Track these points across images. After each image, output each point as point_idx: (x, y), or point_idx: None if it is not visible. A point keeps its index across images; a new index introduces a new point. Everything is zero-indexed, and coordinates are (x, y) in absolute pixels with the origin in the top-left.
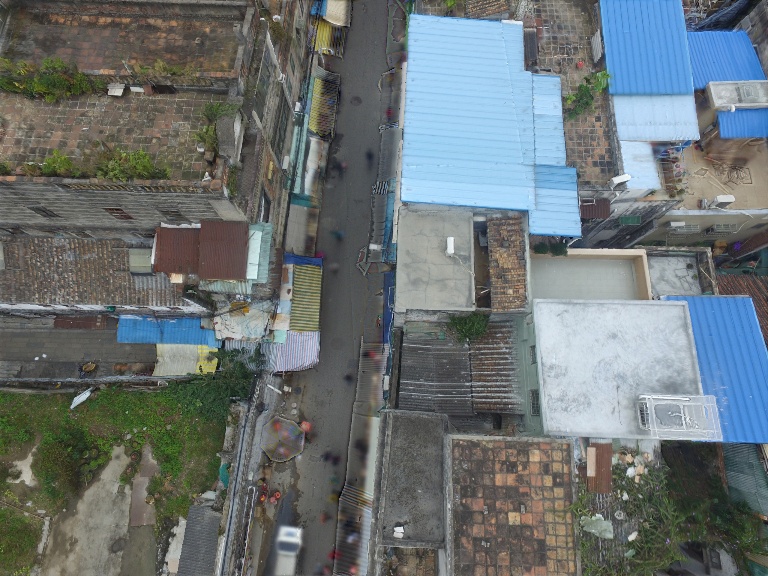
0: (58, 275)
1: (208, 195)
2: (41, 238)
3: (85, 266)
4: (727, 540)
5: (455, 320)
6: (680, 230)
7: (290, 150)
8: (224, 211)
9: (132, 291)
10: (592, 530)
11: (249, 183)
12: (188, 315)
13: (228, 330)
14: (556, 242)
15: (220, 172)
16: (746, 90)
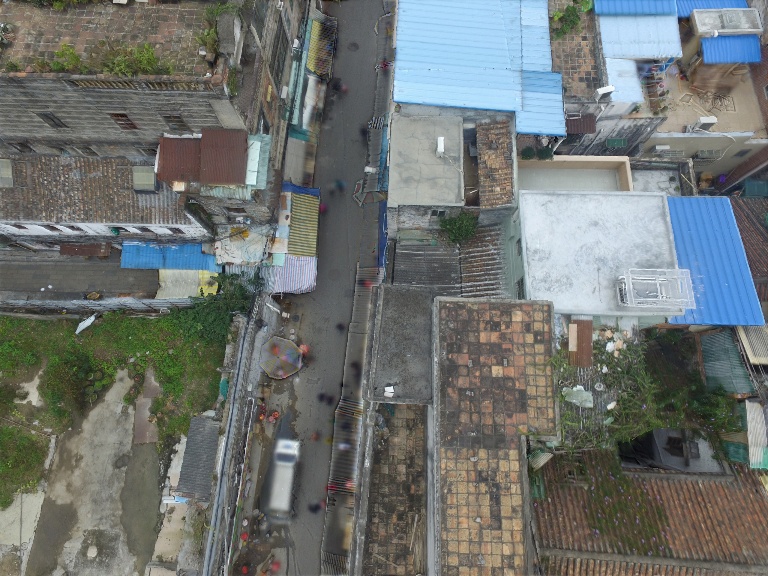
0: (64, 193)
1: (209, 93)
2: (48, 157)
3: (90, 184)
4: (704, 424)
5: (445, 222)
6: (665, 156)
7: (288, 83)
8: (224, 115)
9: (136, 209)
10: (573, 400)
11: (248, 100)
12: (189, 241)
13: (228, 255)
14: (542, 148)
15: (221, 70)
16: (729, 17)
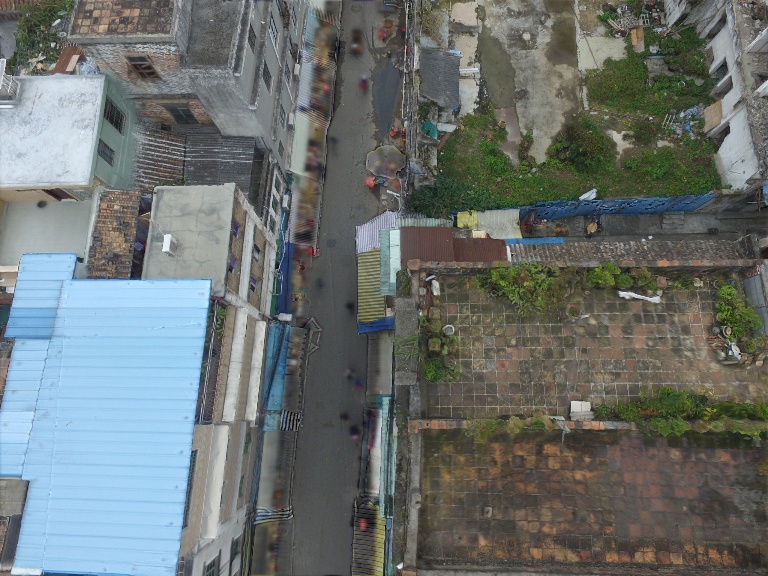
0: None
1: None
2: None
3: None
4: None
5: None
6: None
7: None
8: None
9: (543, 255)
10: None
11: None
12: None
13: None
14: None
15: (414, 285)
16: None
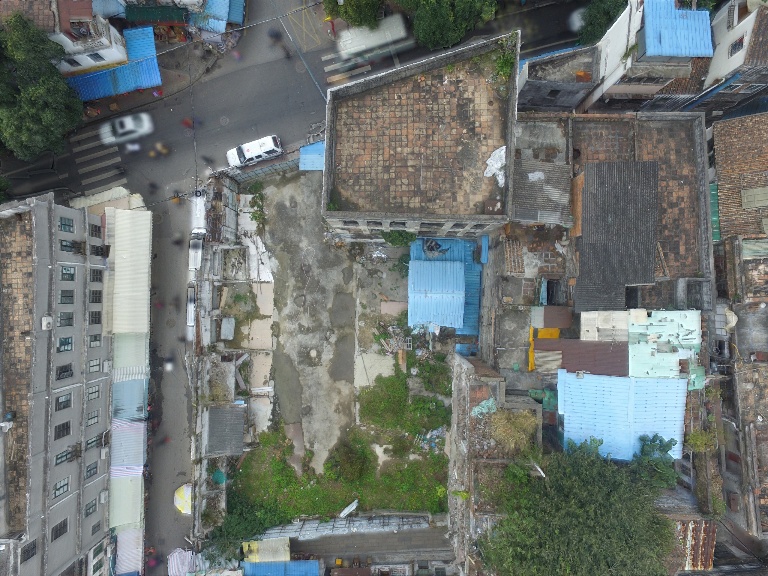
0: None
1: None
2: None
3: None
4: None
5: None
6: None
7: None
8: None
9: None
10: None
11: None
12: None
13: None
14: None
15: None
16: None
